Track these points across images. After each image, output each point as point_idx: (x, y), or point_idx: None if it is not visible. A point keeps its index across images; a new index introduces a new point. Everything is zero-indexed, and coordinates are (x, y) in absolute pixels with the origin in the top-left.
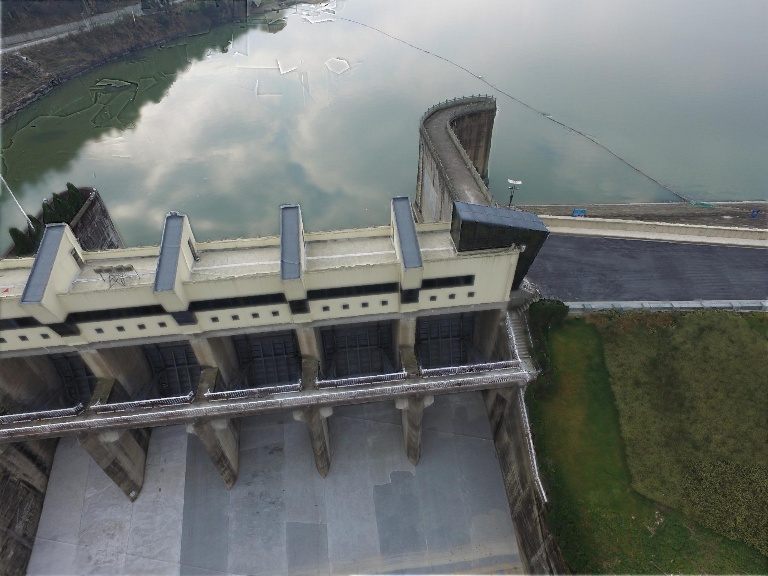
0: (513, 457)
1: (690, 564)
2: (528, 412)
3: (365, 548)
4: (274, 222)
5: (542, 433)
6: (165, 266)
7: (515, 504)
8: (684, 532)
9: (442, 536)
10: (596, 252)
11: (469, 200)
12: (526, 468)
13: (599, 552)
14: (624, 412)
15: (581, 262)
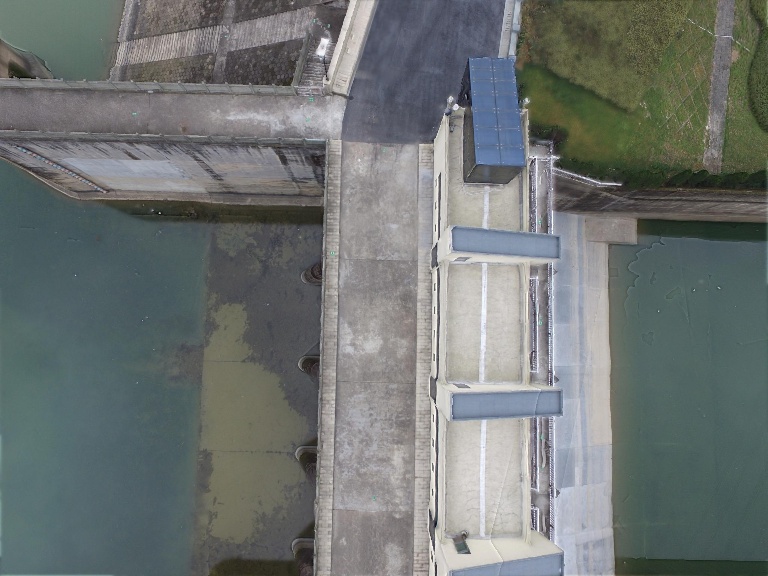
0: (553, 195)
1: (665, 101)
2: (569, 170)
3: (565, 336)
4: (76, 433)
5: (599, 167)
6: (527, 575)
7: (564, 206)
8: (653, 92)
9: (563, 272)
10: (413, 1)
11: (256, 121)
12: (582, 189)
13: (645, 160)
14: (593, 86)
15: (430, 28)
